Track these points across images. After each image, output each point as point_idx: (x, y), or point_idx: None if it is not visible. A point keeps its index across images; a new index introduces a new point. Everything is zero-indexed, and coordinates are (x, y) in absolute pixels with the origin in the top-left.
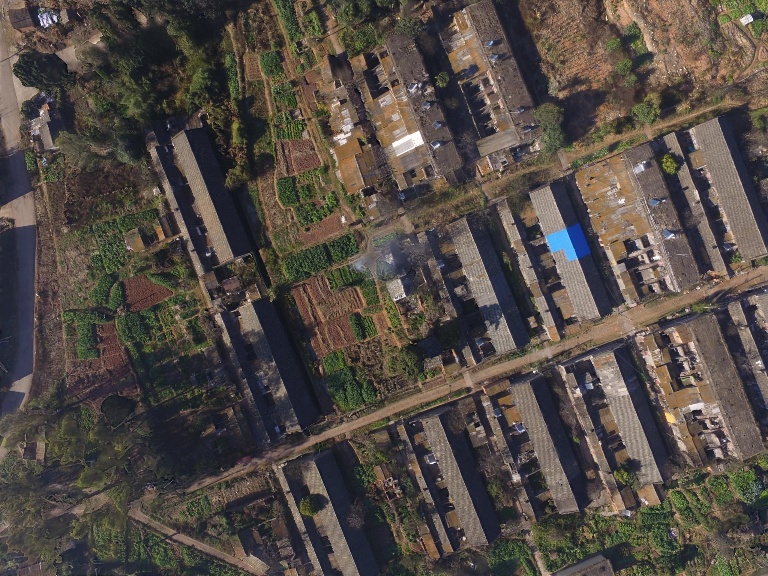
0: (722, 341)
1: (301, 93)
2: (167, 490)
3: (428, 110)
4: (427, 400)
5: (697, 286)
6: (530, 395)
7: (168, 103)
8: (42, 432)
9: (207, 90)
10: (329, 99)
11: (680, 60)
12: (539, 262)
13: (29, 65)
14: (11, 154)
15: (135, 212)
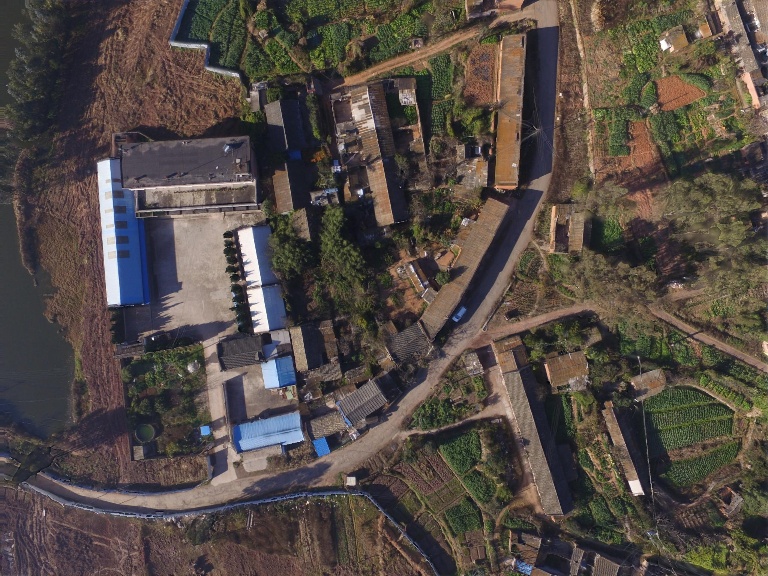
0: None
1: None
2: (693, 288)
3: None
4: None
5: None
6: None
7: None
8: (580, 223)
9: None
10: None
11: None
12: None
13: None
14: None
15: (669, 13)
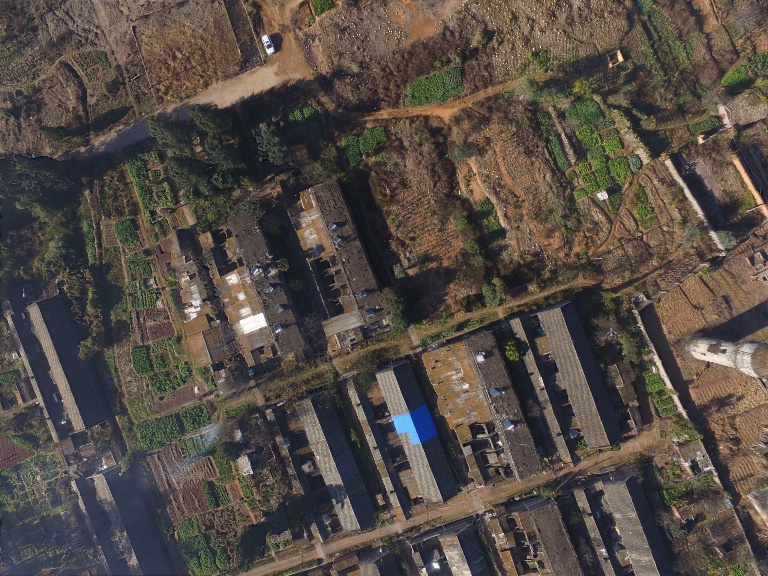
0: (564, 531)
1: (155, 262)
2: None
3: (271, 292)
4: (280, 569)
5: (543, 471)
6: (376, 574)
7: (25, 270)
8: None
9: (63, 257)
10: (179, 273)
11: (533, 237)
12: (386, 441)
13: None
14: None
15: None
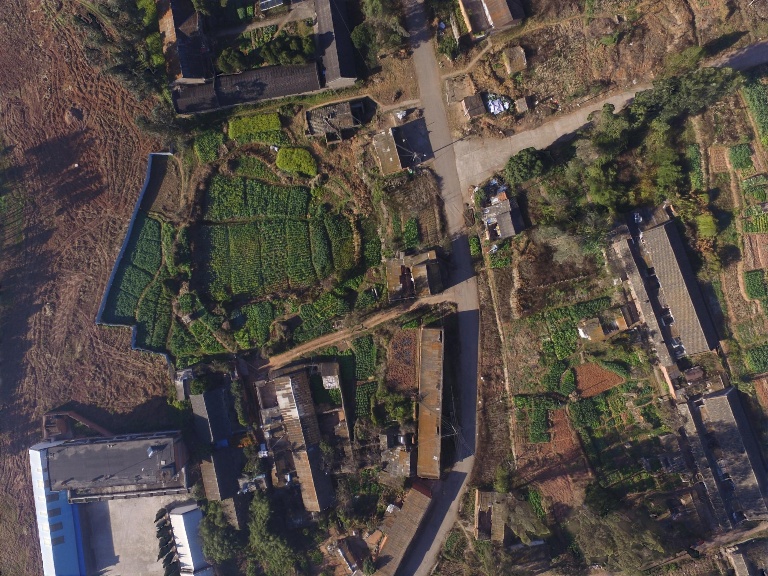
0: None
1: None
2: (614, 570)
3: None
4: None
5: None
6: None
7: (636, 195)
8: None
9: (675, 182)
10: None
11: None
12: None
13: (531, 164)
14: (454, 239)
15: (586, 300)
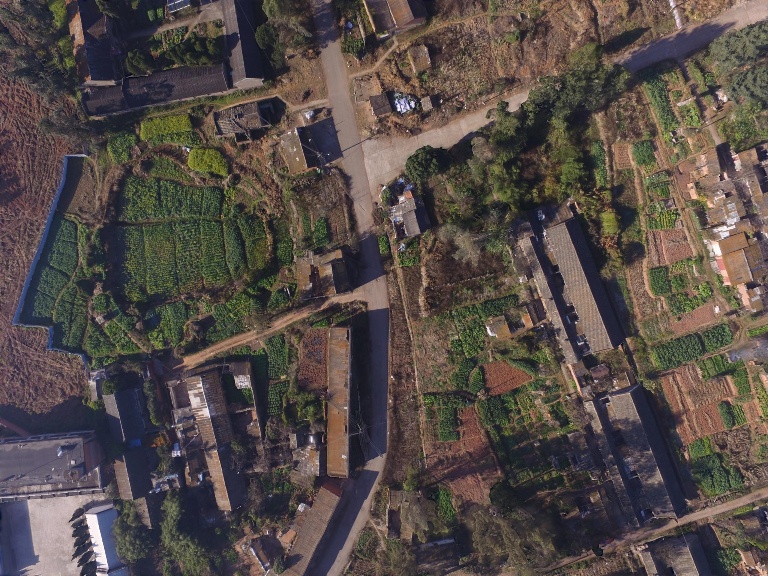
0: None
1: (675, 183)
2: None
3: None
4: None
5: None
6: None
7: (539, 193)
8: None
9: None
10: (712, 191)
11: None
12: None
13: (427, 162)
14: (364, 238)
15: (494, 298)
